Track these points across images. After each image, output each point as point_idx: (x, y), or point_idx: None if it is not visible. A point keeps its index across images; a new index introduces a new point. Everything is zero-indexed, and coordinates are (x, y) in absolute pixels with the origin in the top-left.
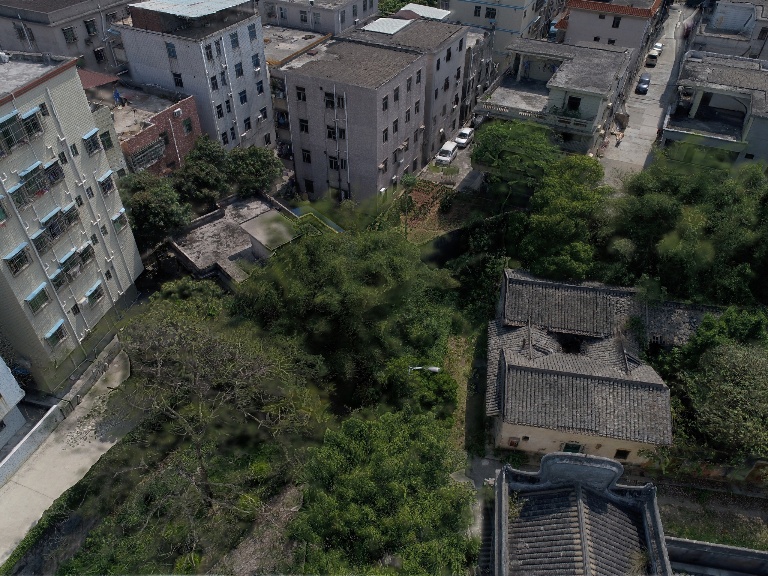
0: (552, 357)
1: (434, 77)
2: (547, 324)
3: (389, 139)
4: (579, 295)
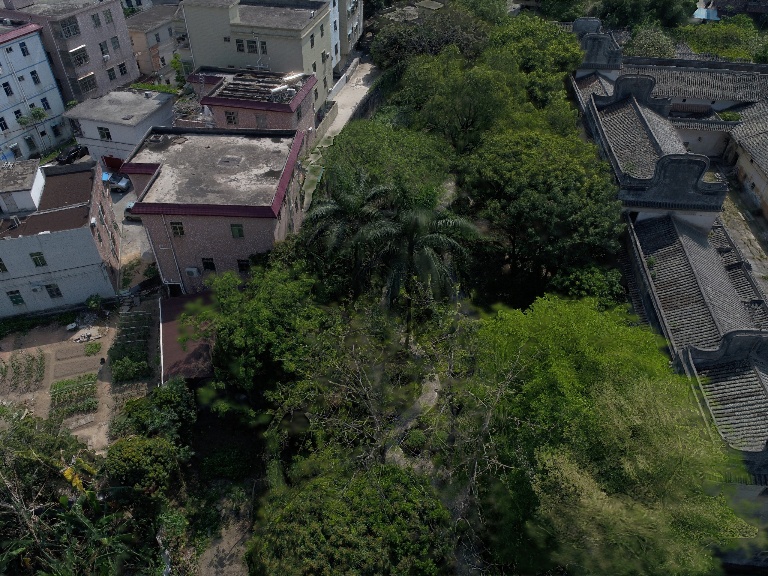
0: None
1: None
2: None
3: None
4: None
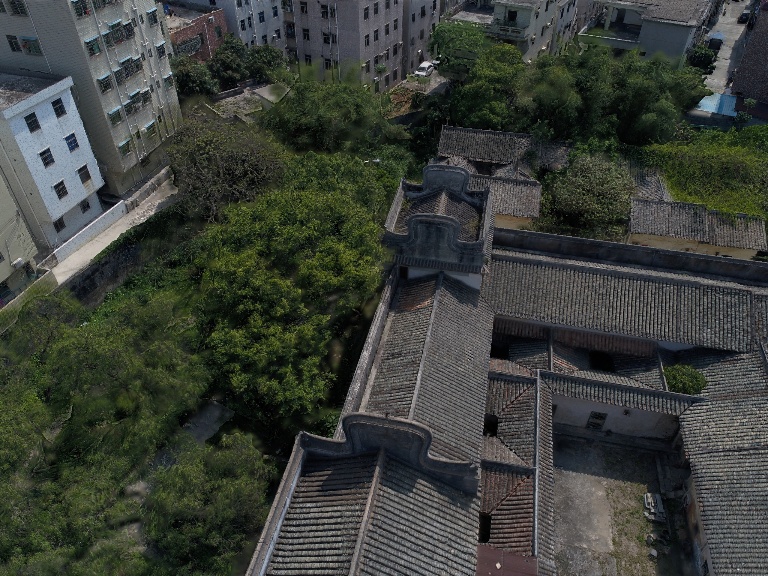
0: None
1: (411, 3)
2: (468, 155)
3: (371, 45)
4: (493, 137)
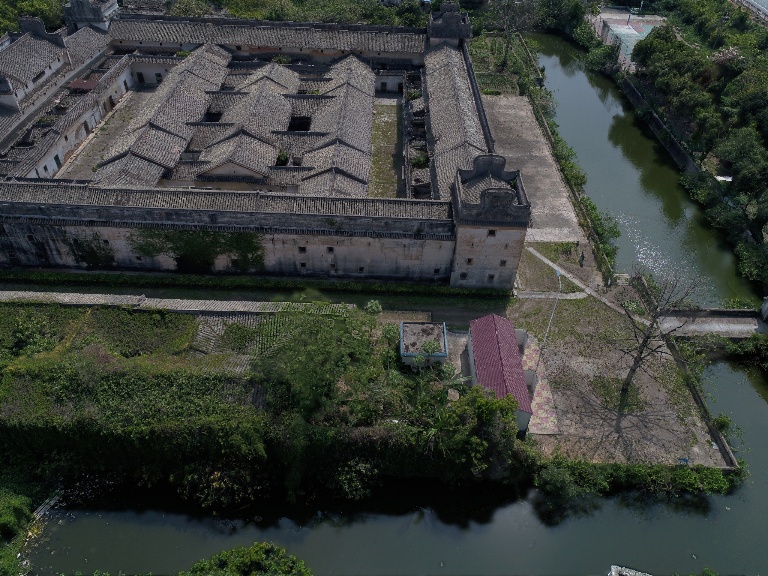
0: None
1: None
2: (138, 5)
3: None
4: None
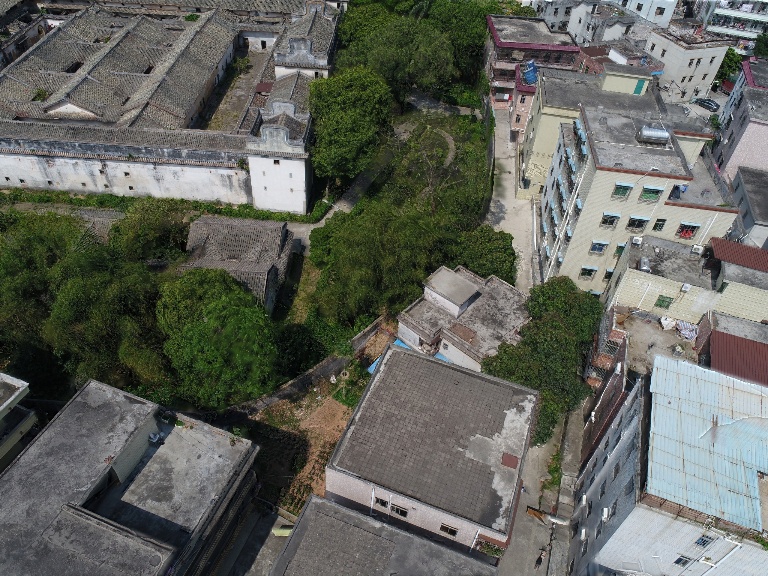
0: (249, 249)
1: None
2: None
3: None
4: None
